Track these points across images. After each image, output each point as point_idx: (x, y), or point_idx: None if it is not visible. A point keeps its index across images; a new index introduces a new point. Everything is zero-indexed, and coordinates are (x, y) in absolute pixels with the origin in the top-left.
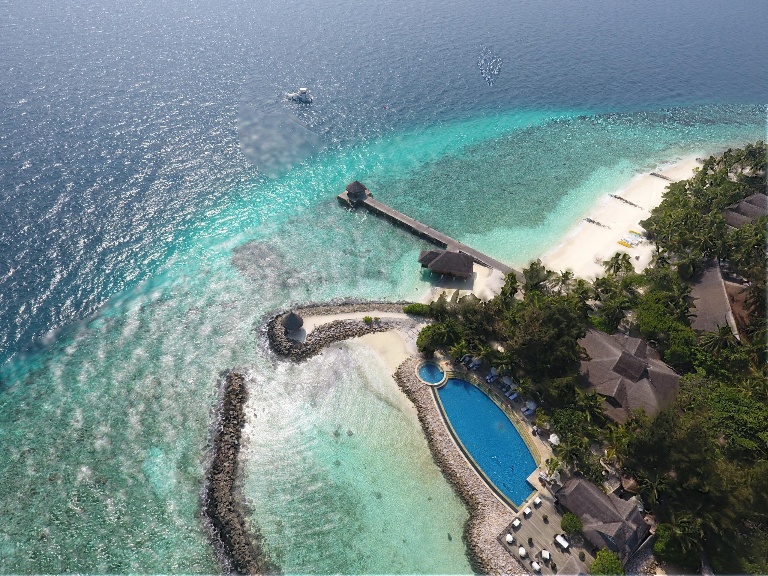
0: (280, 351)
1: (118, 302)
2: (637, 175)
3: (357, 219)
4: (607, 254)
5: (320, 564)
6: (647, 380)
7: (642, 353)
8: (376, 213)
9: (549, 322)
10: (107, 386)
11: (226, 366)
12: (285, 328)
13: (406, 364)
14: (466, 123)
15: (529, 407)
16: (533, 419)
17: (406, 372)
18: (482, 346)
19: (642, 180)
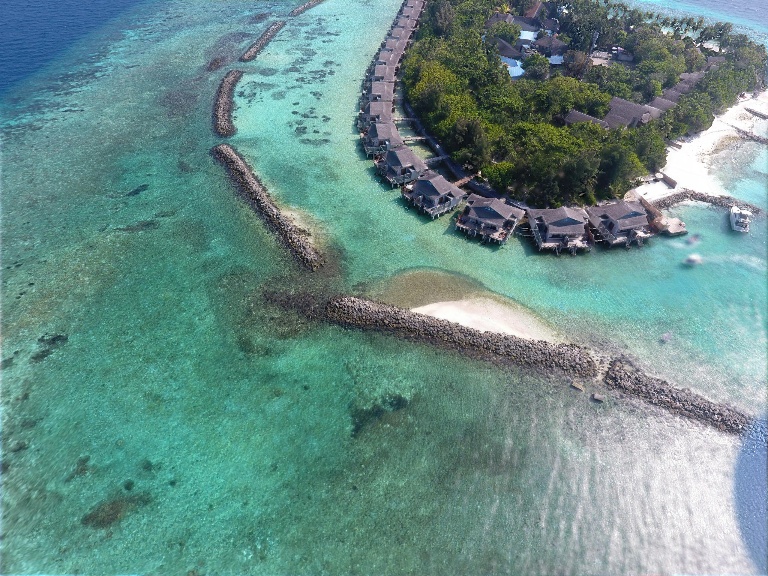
0: None
1: None
2: None
3: None
4: None
5: None
6: None
7: None
8: None
9: None
10: None
11: None
12: None
13: None
14: (696, 8)
15: None
16: None
17: None
18: None
19: None
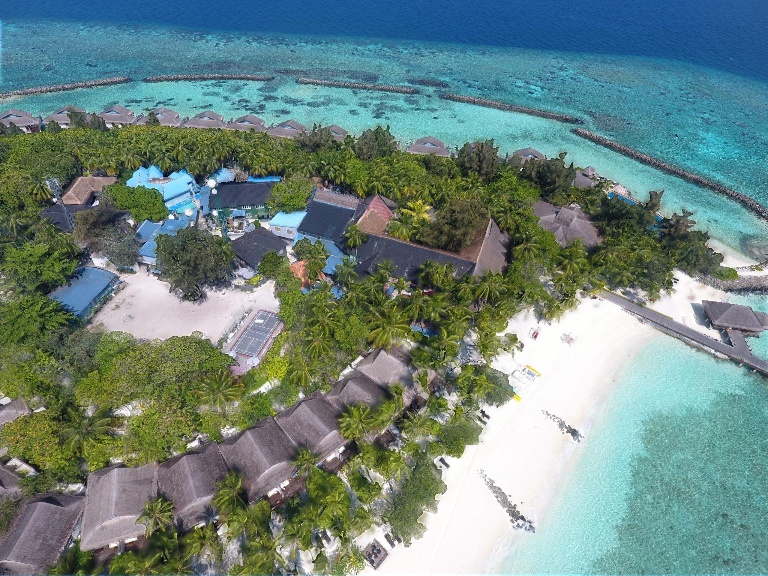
0: None
1: None
2: None
3: None
4: (557, 354)
5: (684, 188)
6: (556, 210)
7: None
8: None
9: None
10: None
11: None
12: None
13: None
14: None
15: None
16: None
17: None
18: None
19: None
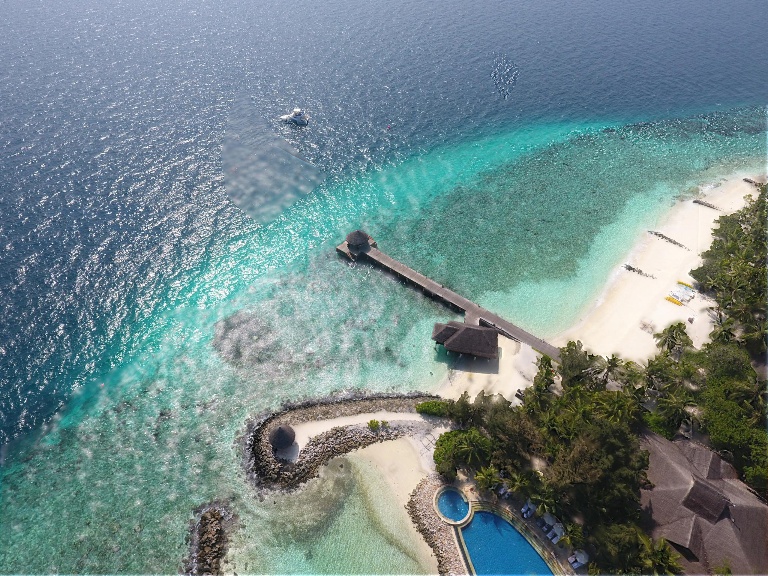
0: (267, 475)
1: (78, 405)
2: (678, 203)
3: (359, 276)
4: (654, 316)
5: None
6: (729, 521)
7: (716, 473)
8: (381, 268)
9: (601, 445)
10: (55, 535)
11: (202, 498)
12: (273, 446)
13: (421, 490)
14: (479, 142)
15: (579, 560)
16: (584, 574)
17: (422, 503)
18: (516, 473)
19: (684, 210)
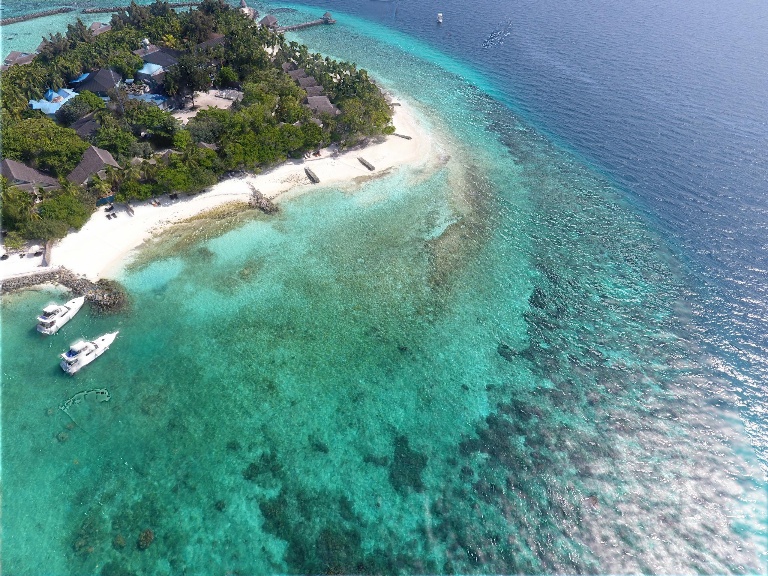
0: None
1: None
2: None
3: None
4: None
5: None
6: None
7: None
8: None
9: None
10: None
11: (235, 6)
12: None
13: None
14: None
15: None
16: None
17: None
18: None
19: None
